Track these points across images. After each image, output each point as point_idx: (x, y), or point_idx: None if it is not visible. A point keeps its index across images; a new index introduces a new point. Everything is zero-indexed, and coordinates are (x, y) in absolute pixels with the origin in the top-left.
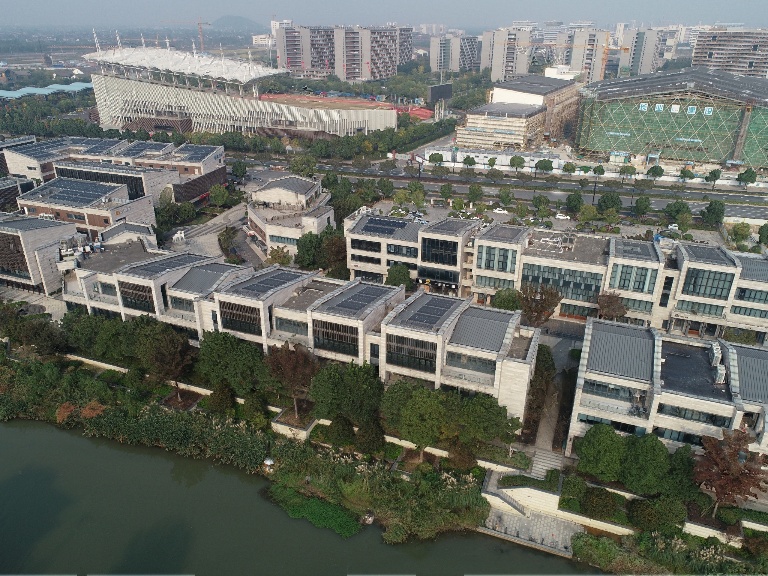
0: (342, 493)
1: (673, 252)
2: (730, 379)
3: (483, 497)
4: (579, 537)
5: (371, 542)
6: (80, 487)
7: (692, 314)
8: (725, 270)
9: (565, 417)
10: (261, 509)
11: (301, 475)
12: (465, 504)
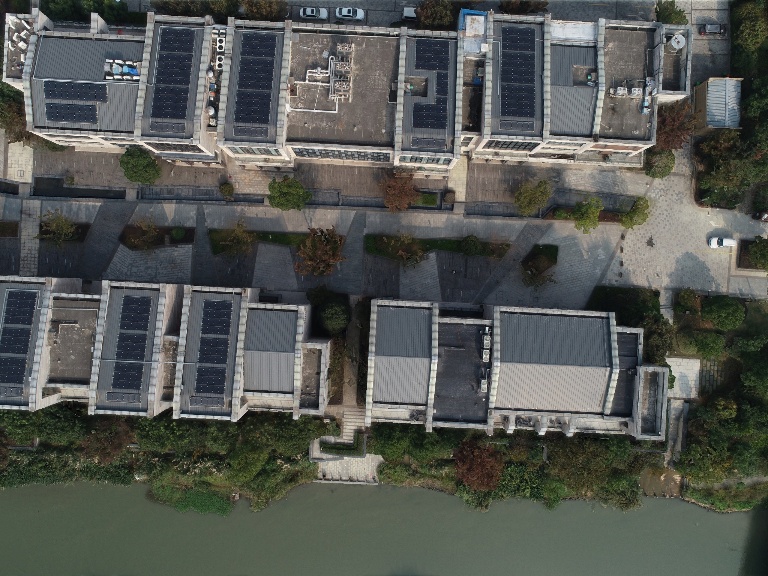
0: (208, 485)
1: (481, 59)
2: (490, 394)
3: (311, 464)
4: (382, 471)
5: (244, 512)
6: (10, 535)
7: (493, 156)
8: (530, 141)
9: (364, 363)
10: (156, 511)
11: (170, 476)
12: (300, 468)
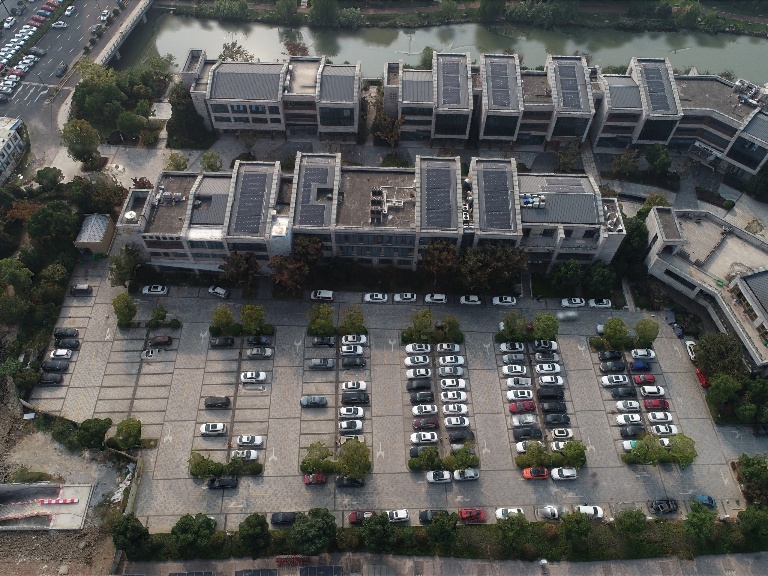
0: None
1: None
2: None
3: None
4: None
5: None
6: None
7: None
8: None
9: (363, 115)
10: None
11: None
12: None
